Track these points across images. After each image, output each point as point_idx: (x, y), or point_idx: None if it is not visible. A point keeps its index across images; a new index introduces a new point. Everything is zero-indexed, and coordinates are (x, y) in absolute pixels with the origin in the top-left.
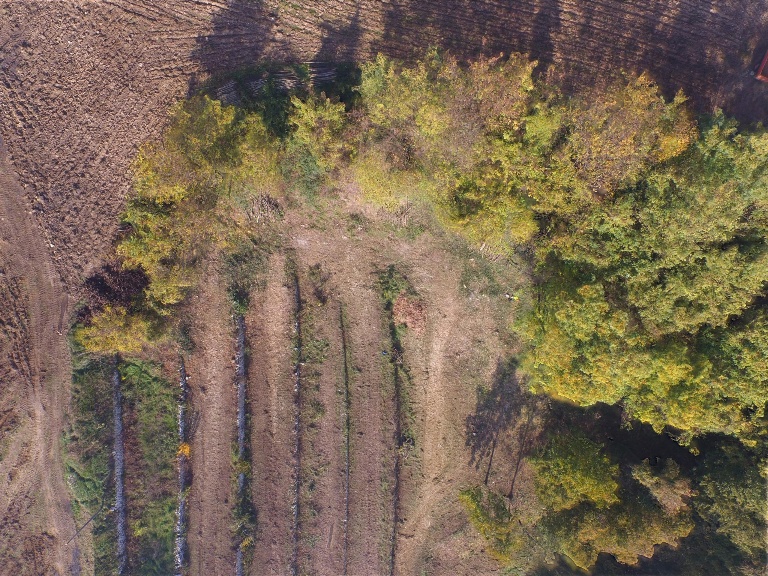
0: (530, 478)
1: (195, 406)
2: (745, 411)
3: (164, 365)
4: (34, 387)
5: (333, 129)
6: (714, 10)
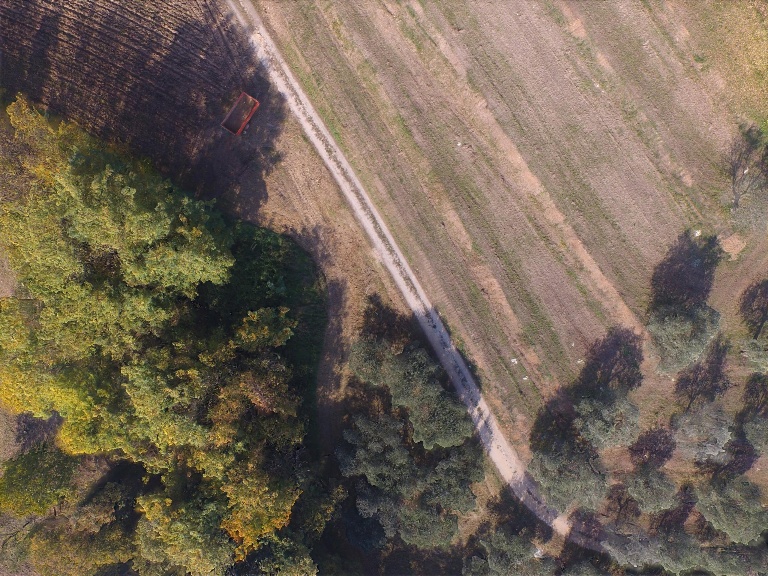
0: None
1: None
2: (173, 447)
3: None
4: None
5: None
6: (204, 56)
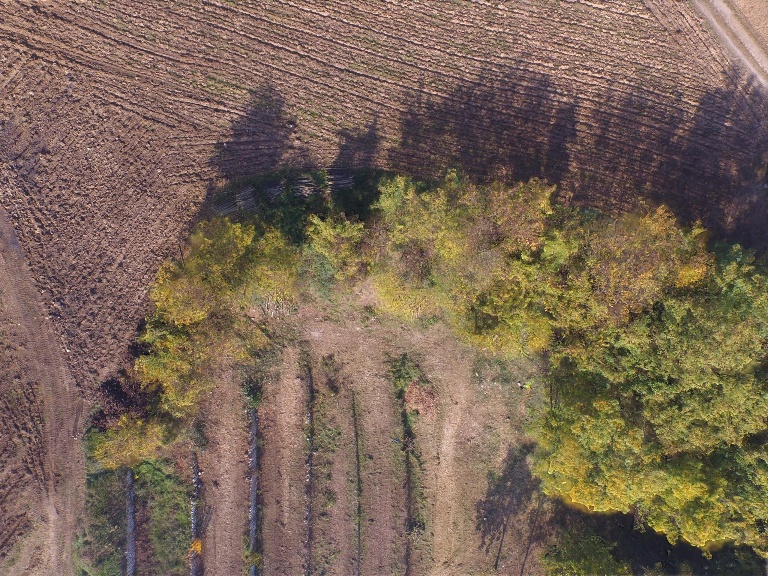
0: (540, 562)
1: (207, 501)
2: (758, 521)
3: (177, 462)
4: (48, 492)
5: (351, 242)
6: (728, 123)
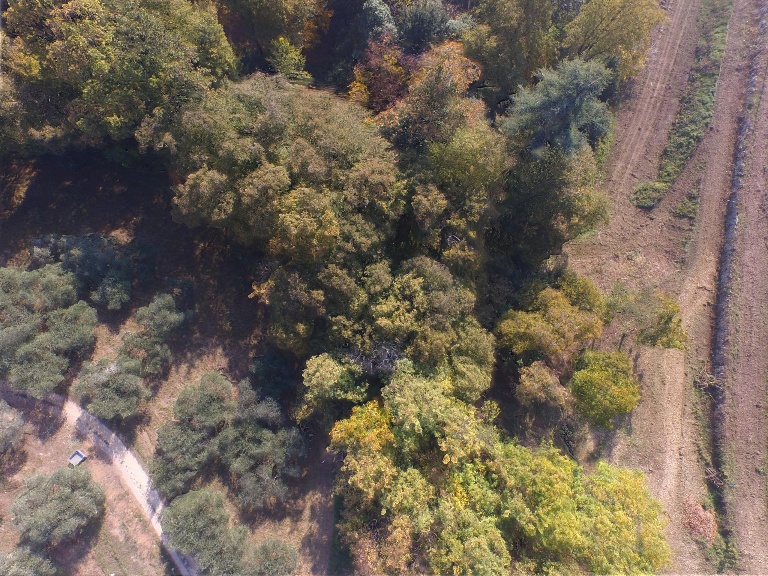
0: None
1: None
2: (465, 457)
3: None
4: None
5: None
6: None
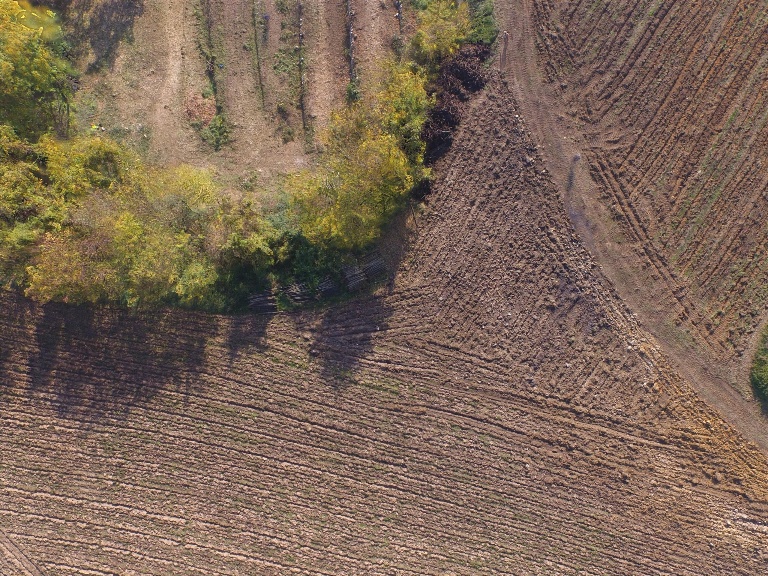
0: None
1: None
2: None
3: None
4: None
5: None
6: None
